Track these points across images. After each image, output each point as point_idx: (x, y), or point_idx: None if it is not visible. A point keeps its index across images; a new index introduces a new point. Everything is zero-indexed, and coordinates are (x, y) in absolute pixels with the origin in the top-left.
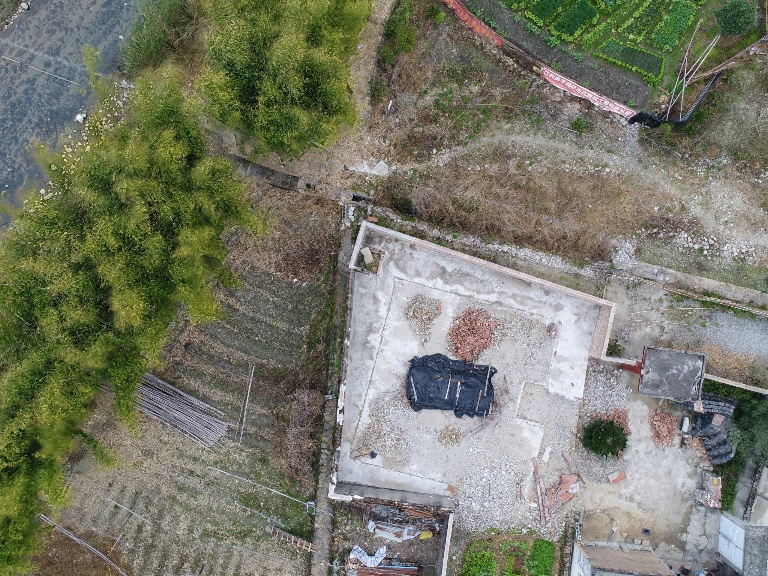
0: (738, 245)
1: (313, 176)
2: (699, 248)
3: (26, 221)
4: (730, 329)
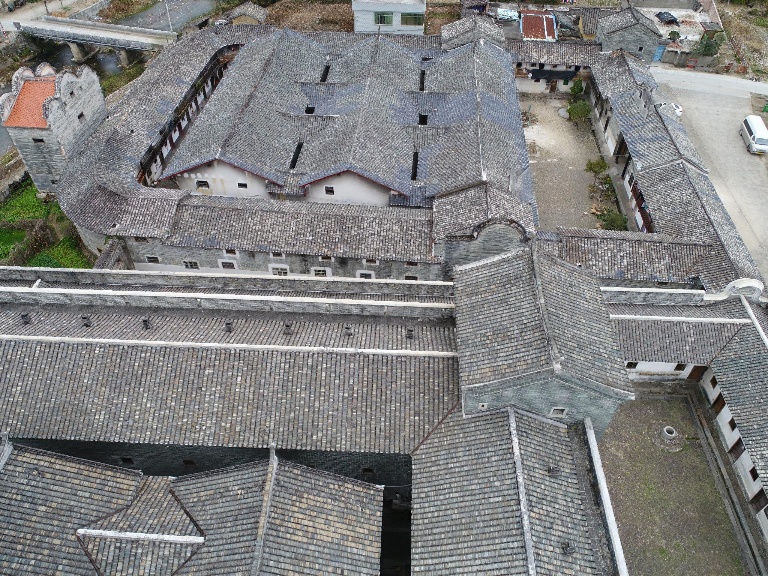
0: (765, 64)
1: None
2: None
3: None
4: None
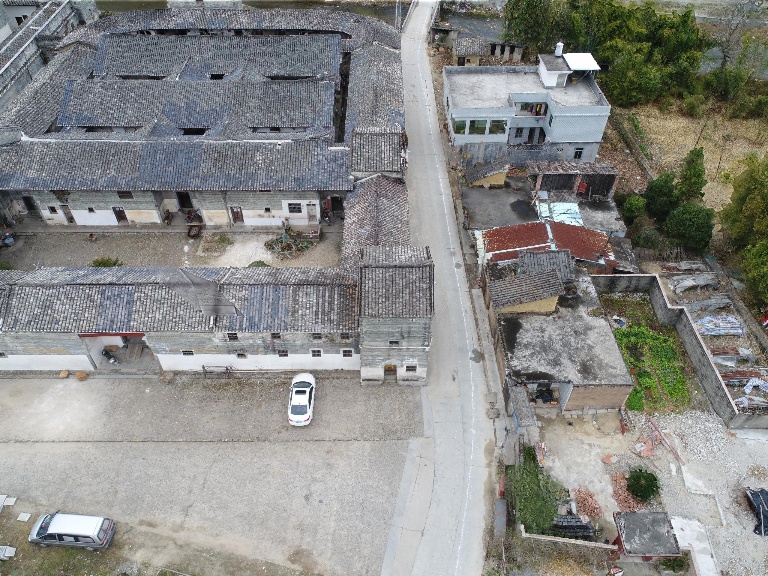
0: None
1: None
2: None
3: None
4: None
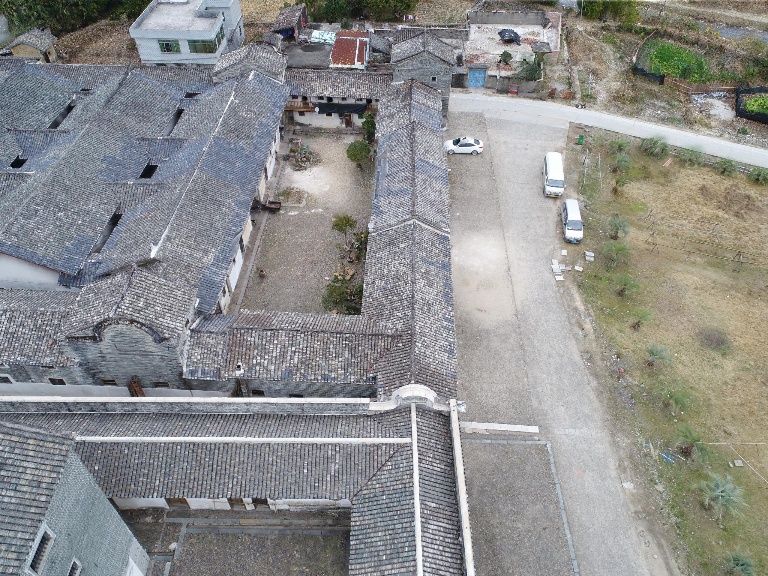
0: None
1: None
2: None
3: None
4: None
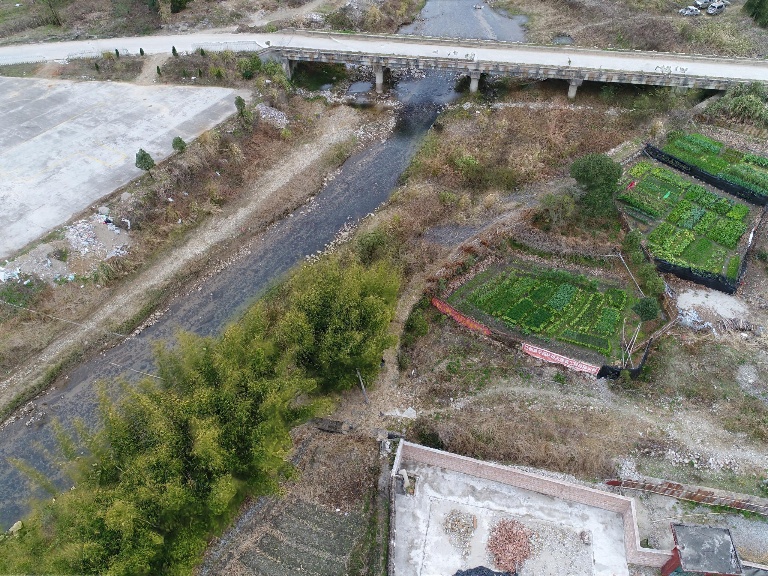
0: (720, 458)
1: (354, 421)
2: (689, 462)
3: (148, 394)
4: (748, 531)
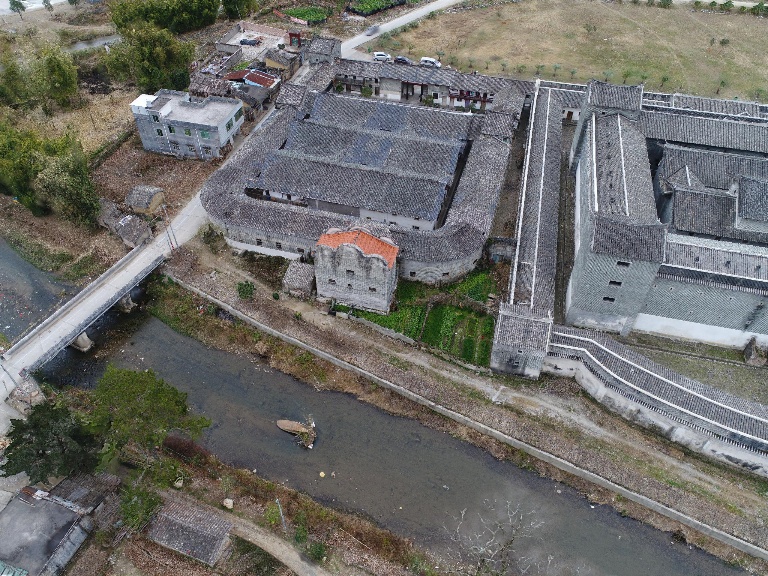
0: None
1: None
2: None
3: None
4: None
